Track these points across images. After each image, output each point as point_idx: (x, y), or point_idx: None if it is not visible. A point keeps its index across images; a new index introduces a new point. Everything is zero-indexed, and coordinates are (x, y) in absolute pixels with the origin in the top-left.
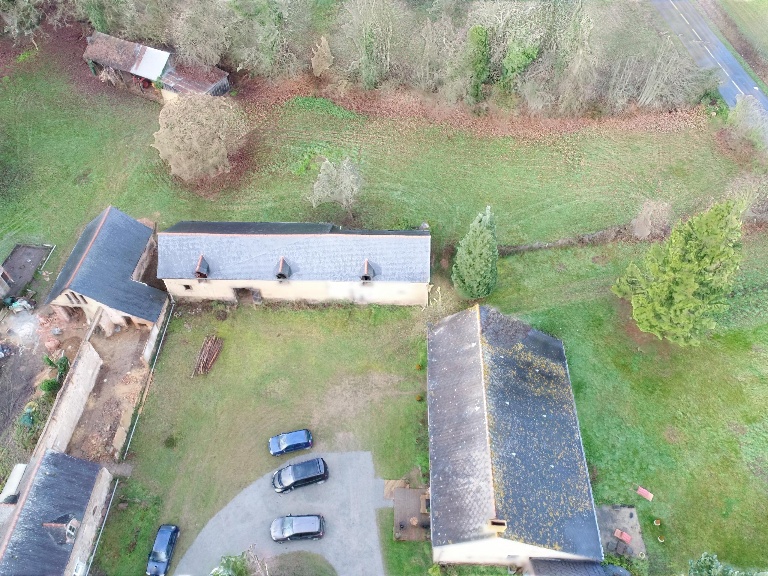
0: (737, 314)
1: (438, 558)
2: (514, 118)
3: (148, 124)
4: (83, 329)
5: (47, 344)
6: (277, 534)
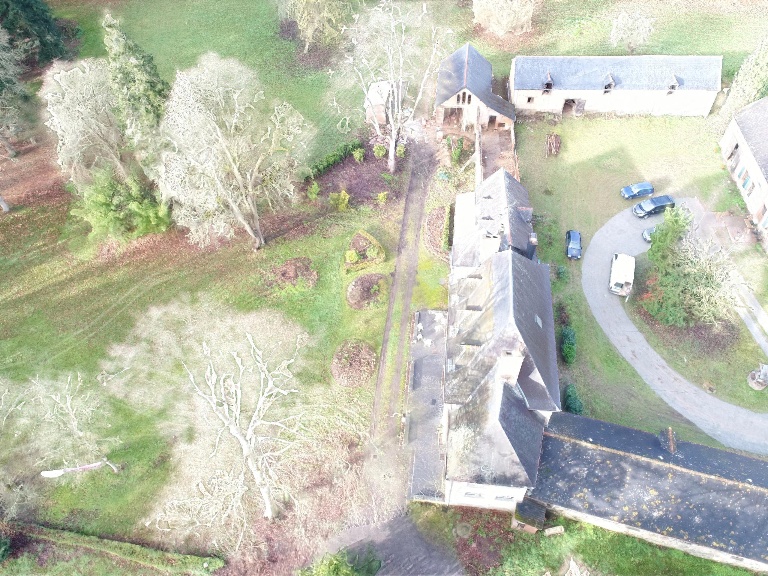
0: None
1: None
2: (734, 0)
3: (442, 6)
4: (455, 129)
5: (439, 134)
6: None
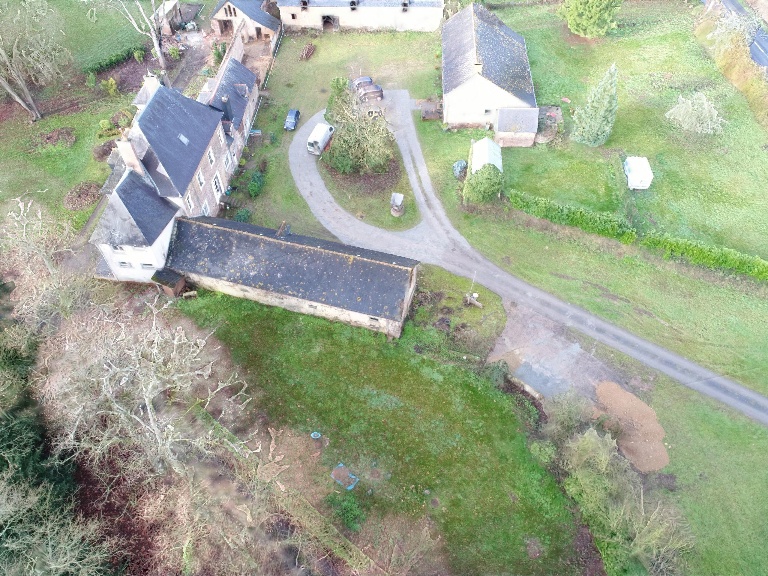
0: (635, 33)
1: (446, 117)
2: None
3: None
4: (230, 39)
5: (211, 41)
6: None
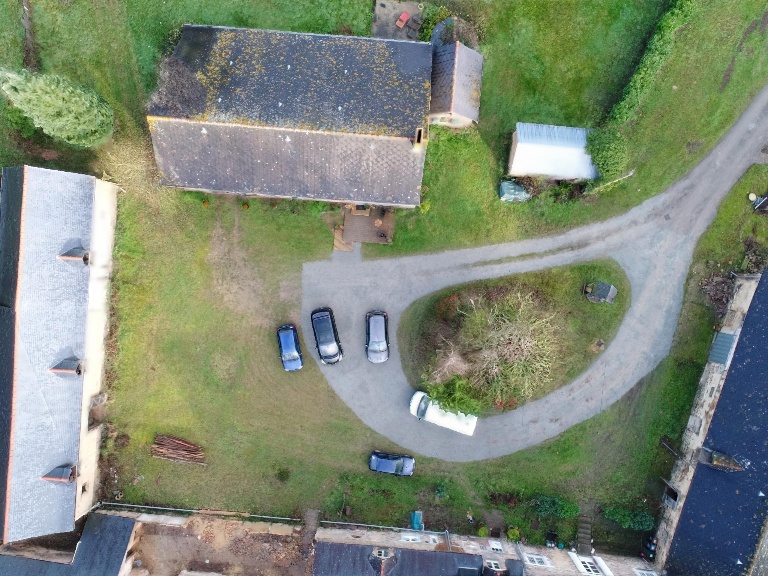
0: None
1: None
2: None
3: None
4: None
5: None
6: (383, 357)
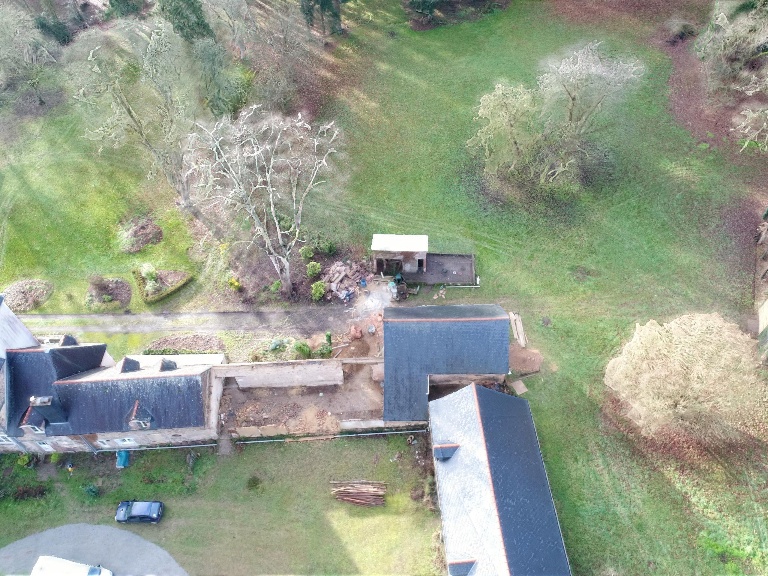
0: None
1: None
2: None
3: (706, 305)
4: None
5: (352, 328)
6: None
